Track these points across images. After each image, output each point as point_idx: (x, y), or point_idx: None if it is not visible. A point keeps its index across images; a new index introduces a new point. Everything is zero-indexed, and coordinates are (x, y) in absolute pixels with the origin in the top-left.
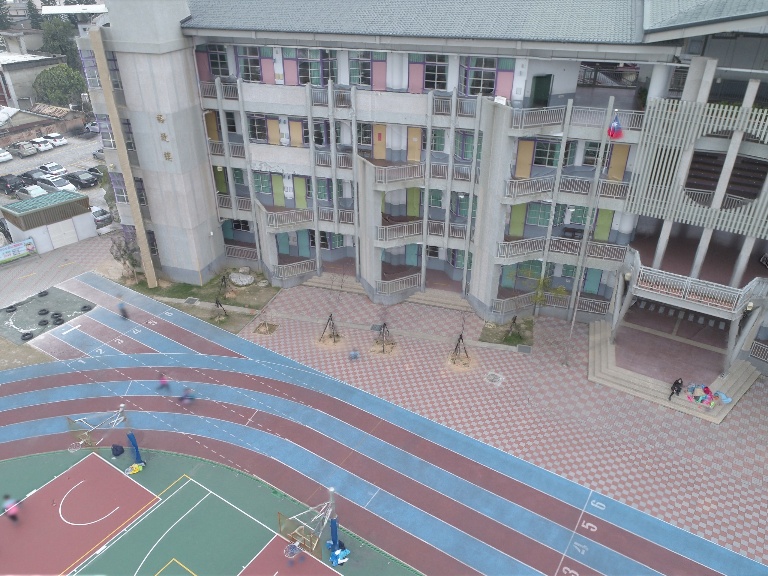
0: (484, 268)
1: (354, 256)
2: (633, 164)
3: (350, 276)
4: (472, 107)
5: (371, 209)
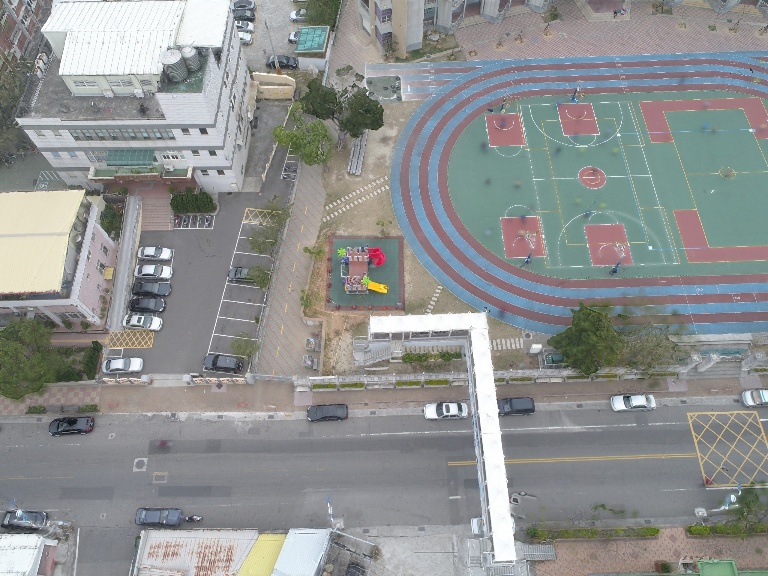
0: None
1: (466, 4)
2: None
3: (476, 16)
4: None
5: None
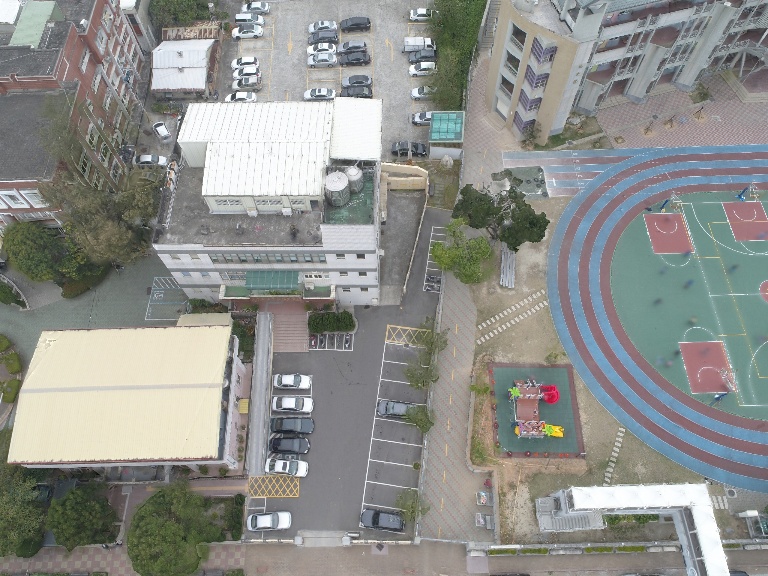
0: (693, 71)
1: None
2: (764, 10)
3: (618, 95)
4: (710, 7)
5: (656, 66)
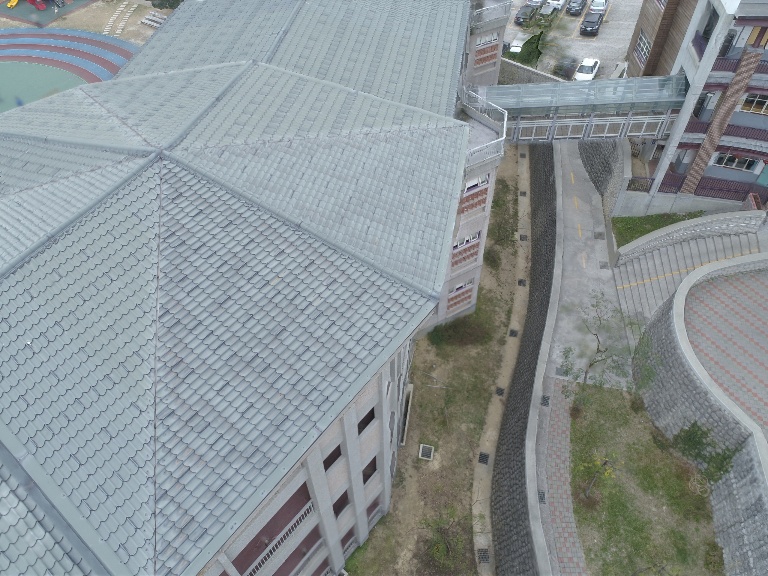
0: None
1: None
2: None
3: None
4: None
5: None
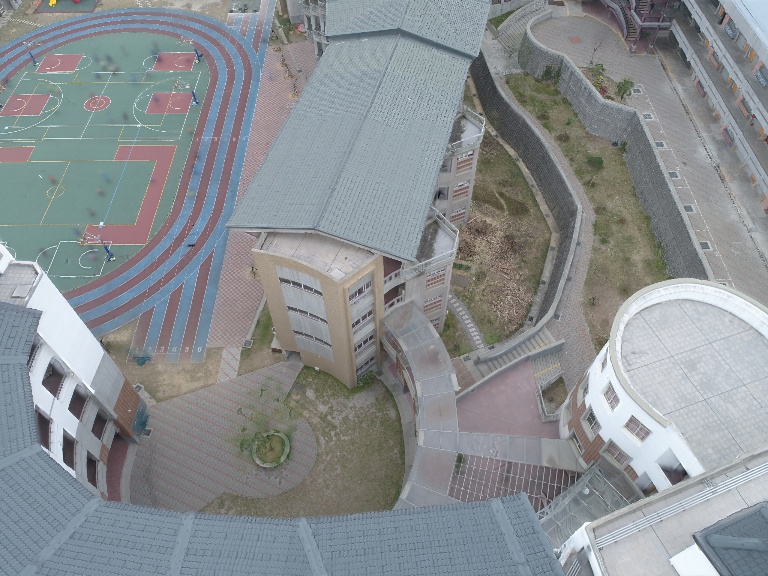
0: None
1: None
2: None
3: None
4: None
5: None
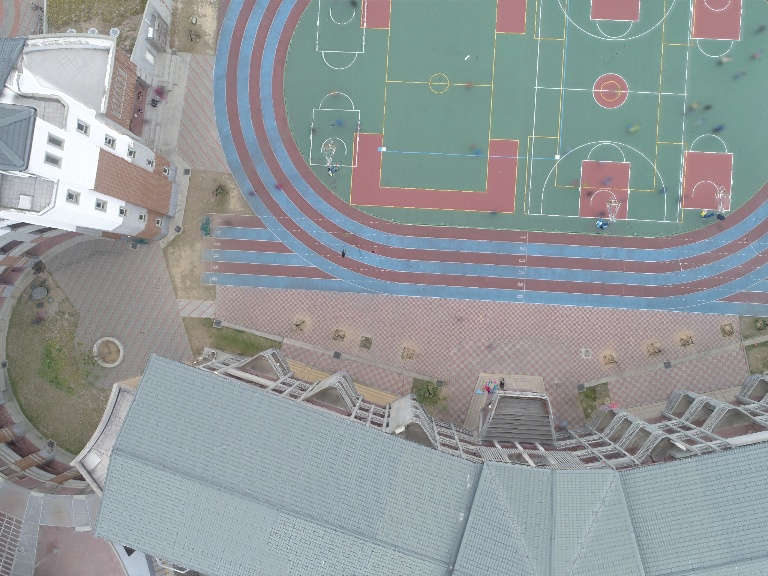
0: None
1: None
2: None
3: None
4: None
5: None
